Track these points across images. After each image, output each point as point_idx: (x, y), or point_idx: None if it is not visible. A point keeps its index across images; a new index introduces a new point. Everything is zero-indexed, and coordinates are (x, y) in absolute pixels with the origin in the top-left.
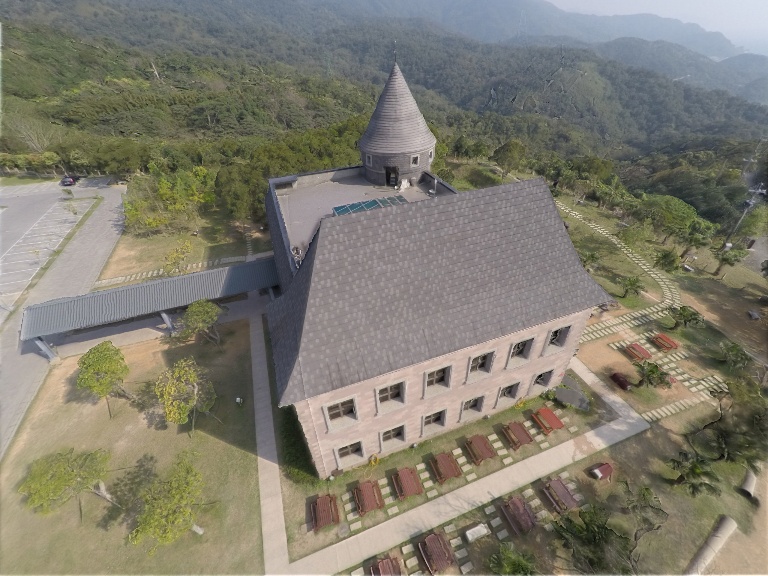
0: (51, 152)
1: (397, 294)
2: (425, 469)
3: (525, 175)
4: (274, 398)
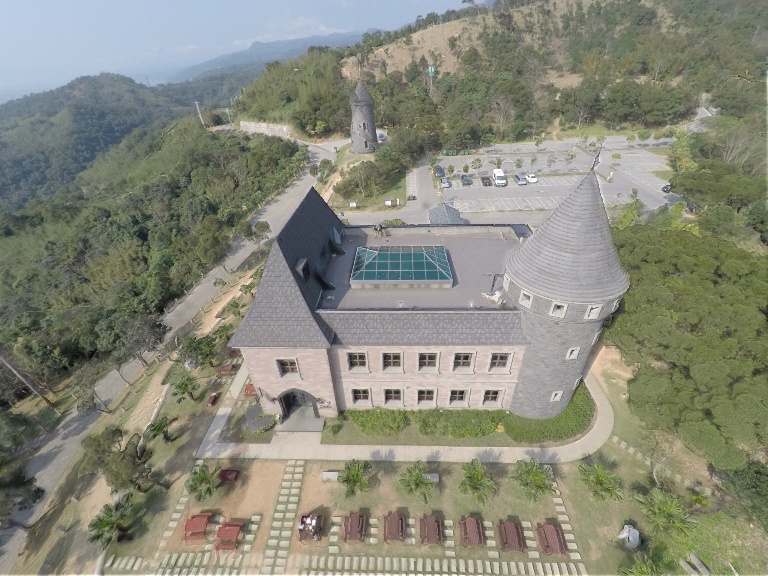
0: (696, 164)
1: None
2: None
3: None
4: None
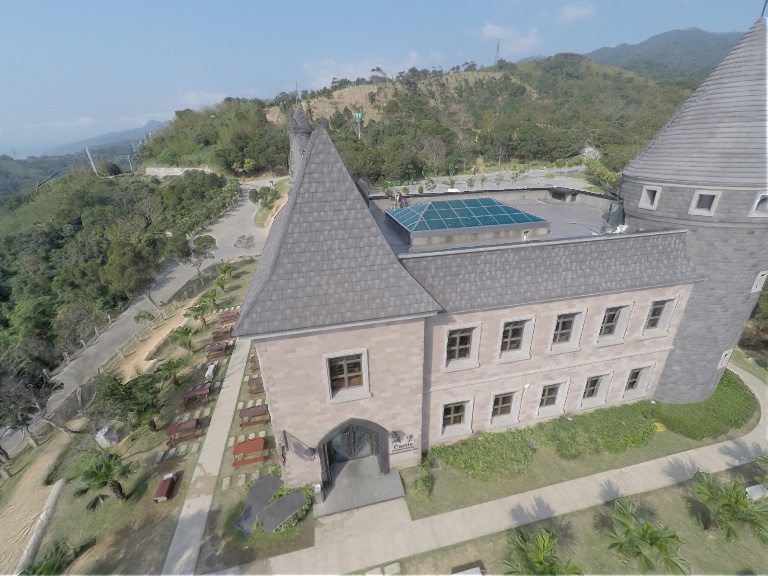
0: None
1: None
2: None
3: None
4: None
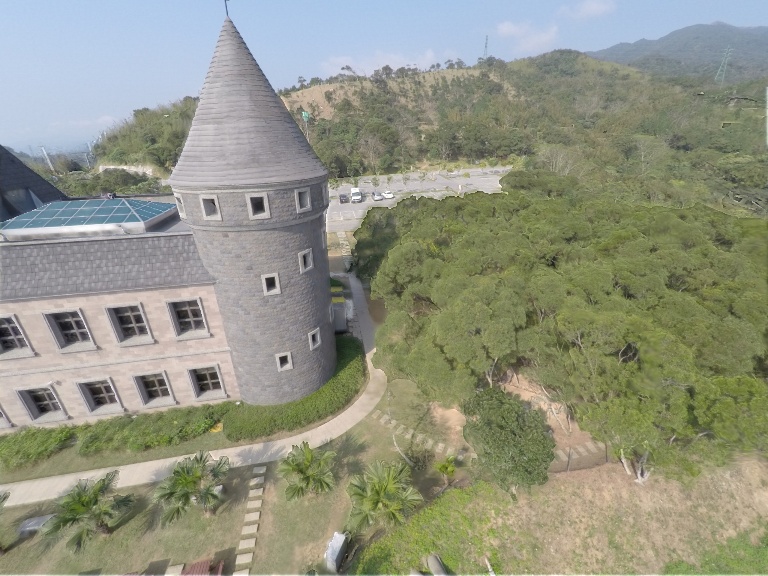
0: None
1: None
2: None
3: None
4: None
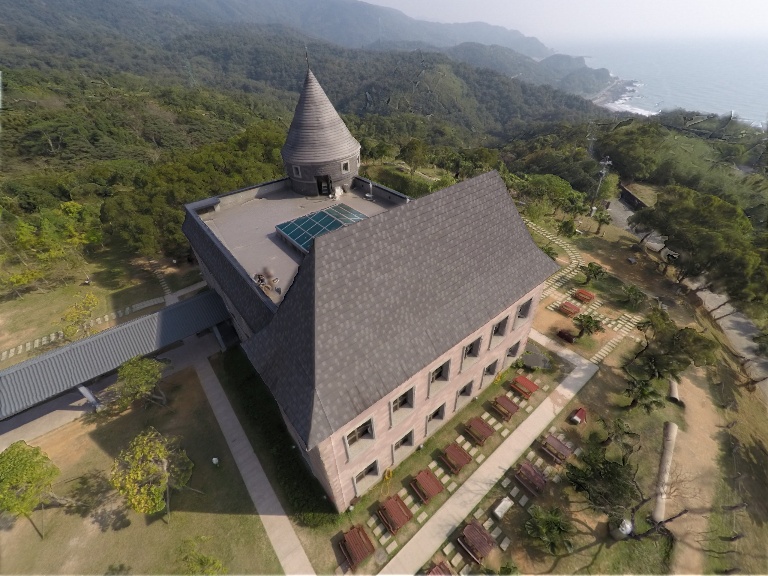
0: None
1: (397, 301)
2: (437, 466)
3: (428, 170)
4: (256, 445)
